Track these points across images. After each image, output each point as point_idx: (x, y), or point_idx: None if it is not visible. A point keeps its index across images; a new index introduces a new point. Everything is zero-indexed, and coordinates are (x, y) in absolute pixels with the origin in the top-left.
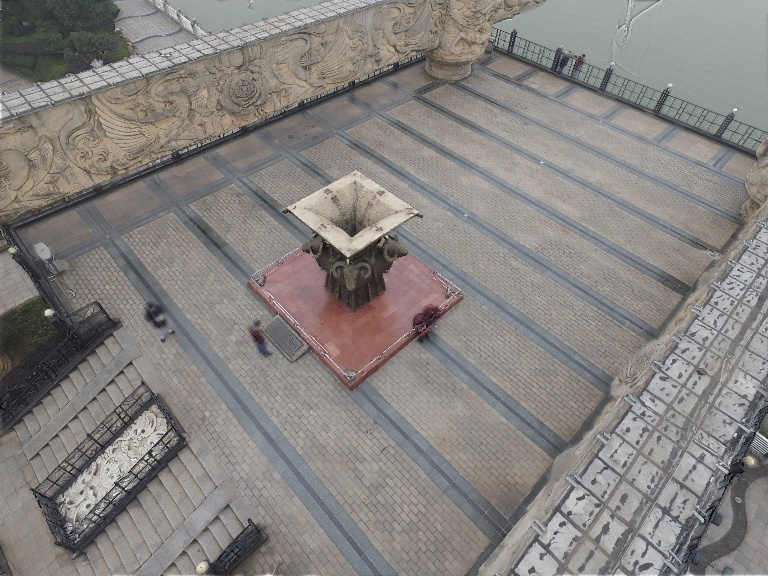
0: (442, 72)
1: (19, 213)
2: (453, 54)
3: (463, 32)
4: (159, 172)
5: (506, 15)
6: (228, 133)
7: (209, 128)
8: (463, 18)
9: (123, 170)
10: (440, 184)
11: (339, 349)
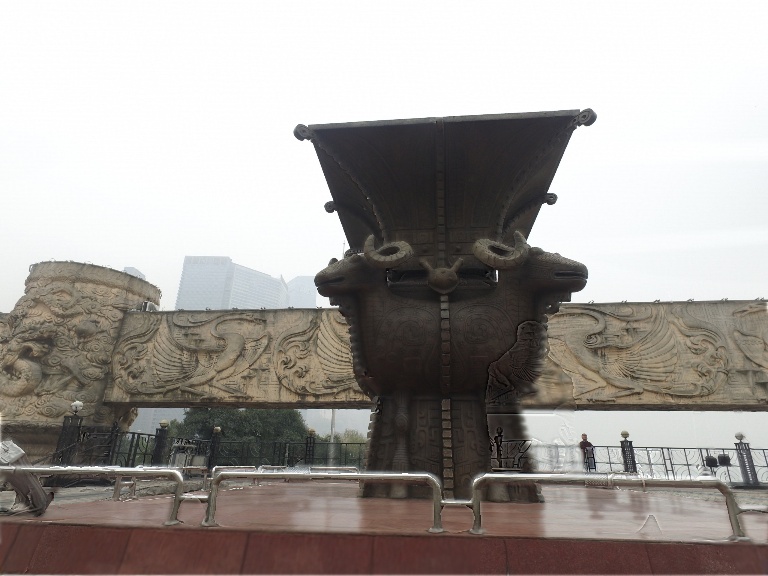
0: None
1: (203, 397)
2: None
3: None
4: None
5: None
6: None
7: None
8: None
9: (313, 398)
10: None
11: None
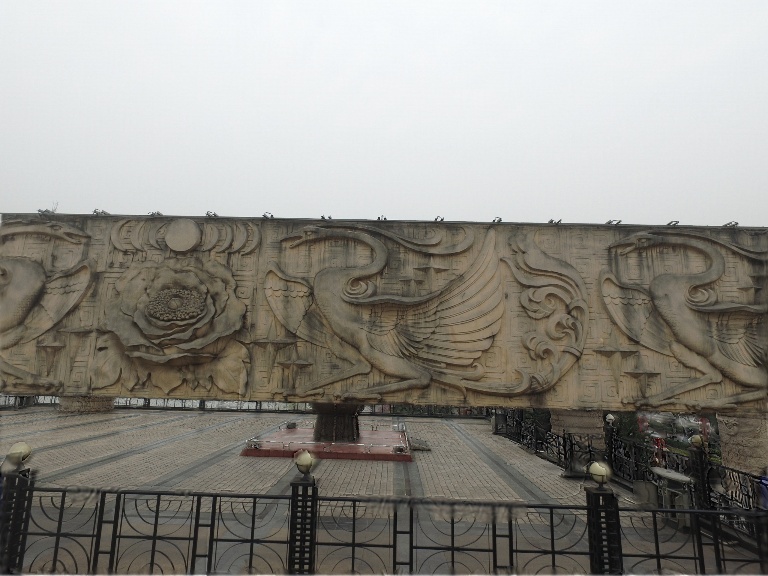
0: None
1: None
2: None
3: None
4: None
5: None
6: (68, 567)
7: None
8: None
9: None
10: (118, 448)
11: (392, 434)
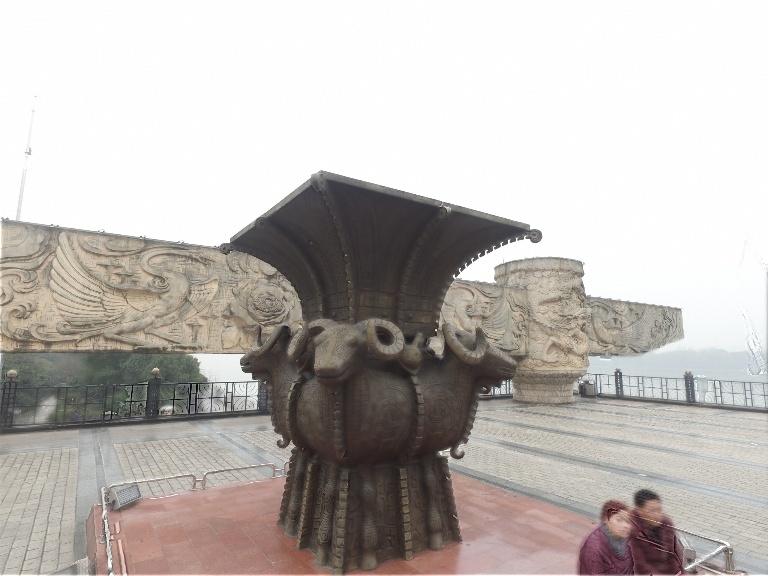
0: (536, 393)
1: None
2: (546, 363)
3: (553, 337)
4: (113, 426)
5: (602, 351)
6: (239, 408)
7: (203, 337)
8: (550, 322)
9: (42, 345)
10: (566, 449)
11: None
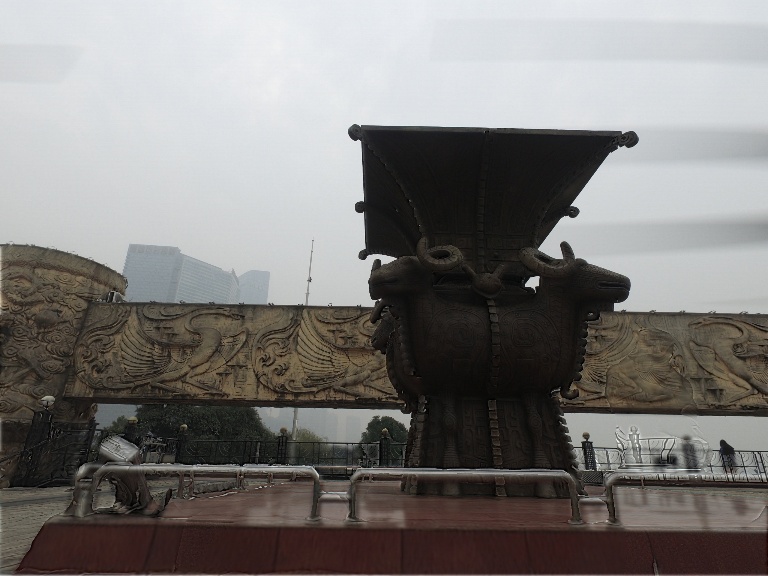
0: None
1: (175, 393)
2: None
3: None
4: None
5: None
6: None
7: None
8: None
9: (292, 396)
10: None
11: None
